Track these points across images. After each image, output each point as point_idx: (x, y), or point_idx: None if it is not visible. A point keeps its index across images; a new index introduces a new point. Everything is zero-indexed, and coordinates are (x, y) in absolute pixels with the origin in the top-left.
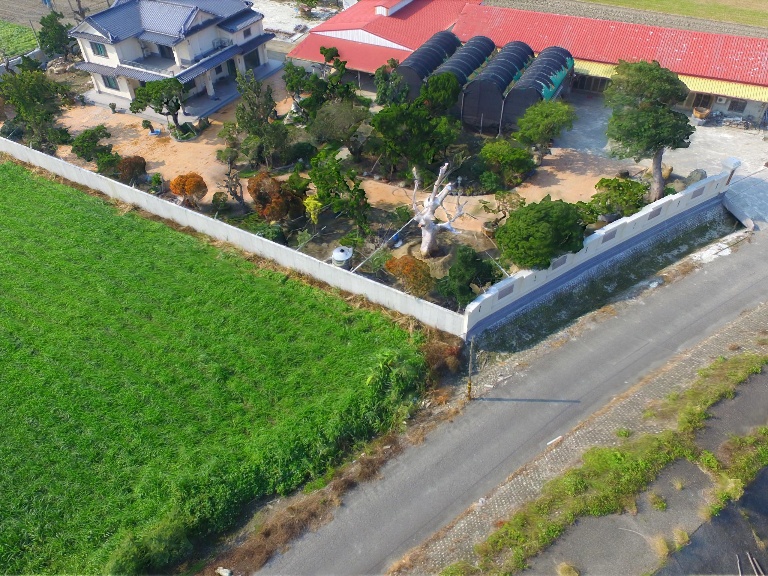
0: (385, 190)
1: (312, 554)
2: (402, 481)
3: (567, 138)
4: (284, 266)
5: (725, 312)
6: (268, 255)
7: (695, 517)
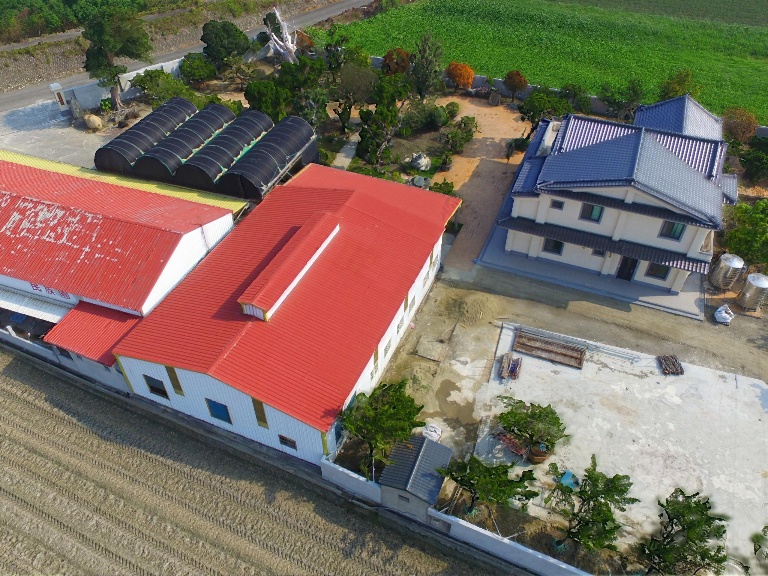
0: None
1: (338, 11)
2: (308, 22)
3: None
4: None
5: (137, 63)
6: None
7: None
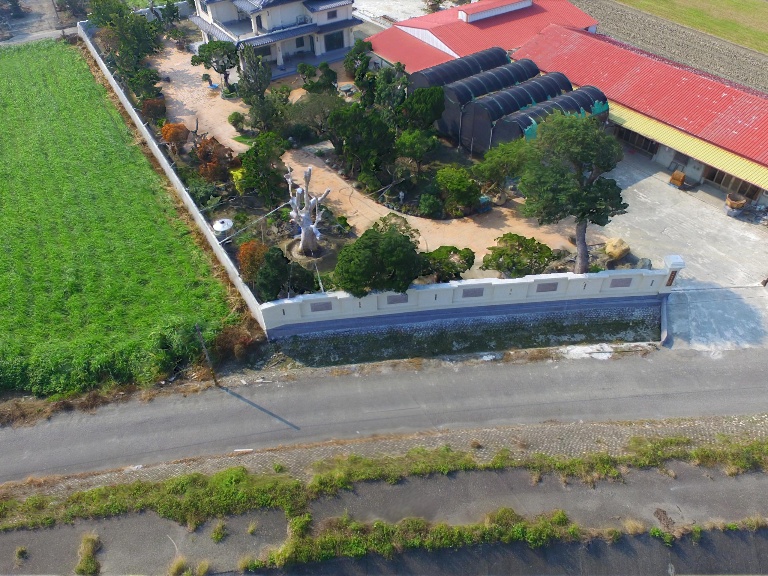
0: (337, 185)
1: None
2: (103, 423)
3: None
4: (196, 223)
5: (530, 412)
6: (190, 209)
7: (234, 562)
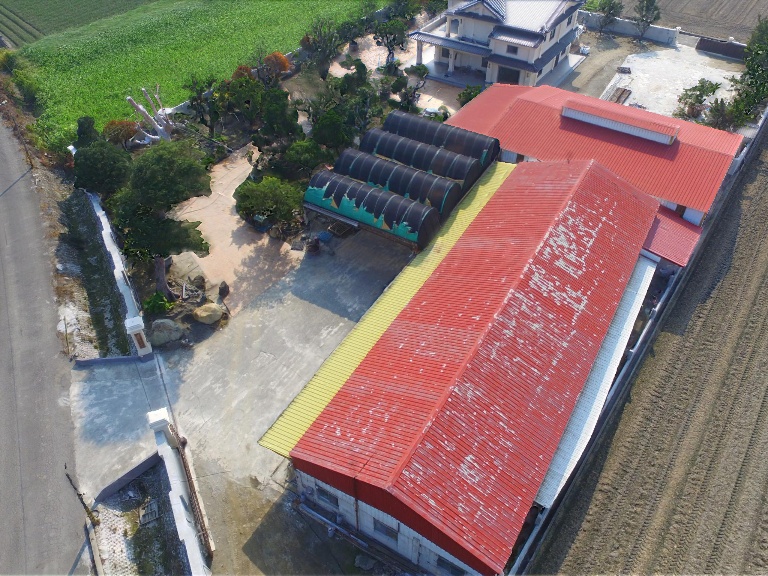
0: None
1: None
2: (4, 143)
3: (323, 267)
4: None
5: None
6: None
7: None
